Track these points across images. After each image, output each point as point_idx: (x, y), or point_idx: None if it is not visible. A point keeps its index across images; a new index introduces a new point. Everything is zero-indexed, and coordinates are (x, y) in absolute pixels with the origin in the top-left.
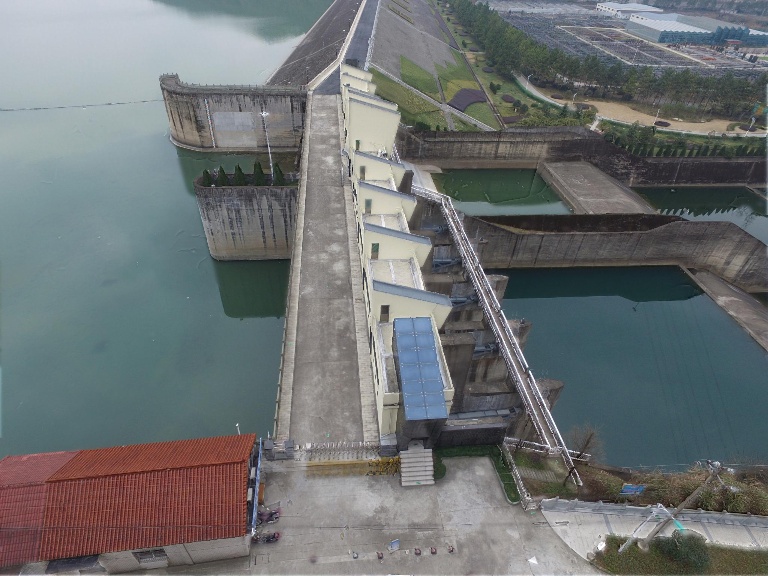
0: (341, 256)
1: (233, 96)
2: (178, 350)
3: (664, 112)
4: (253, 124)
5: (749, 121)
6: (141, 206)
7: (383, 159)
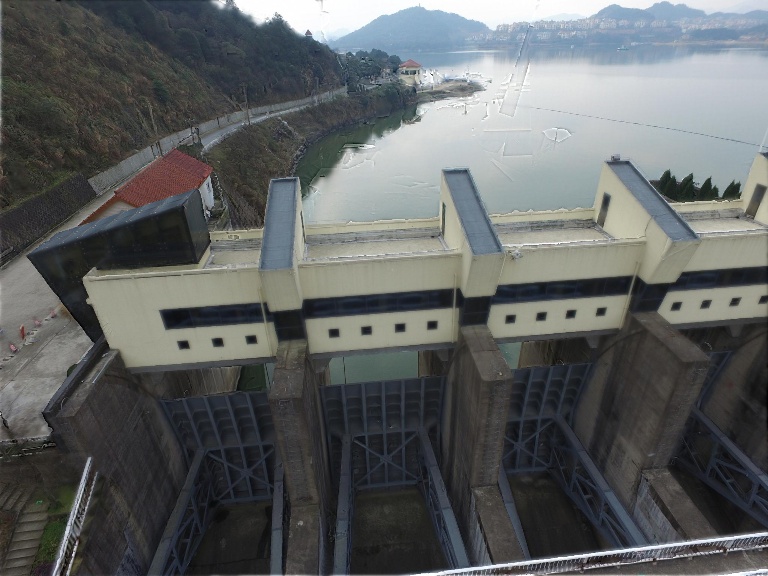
0: None
1: None
2: None
3: None
4: None
5: None
6: None
7: None
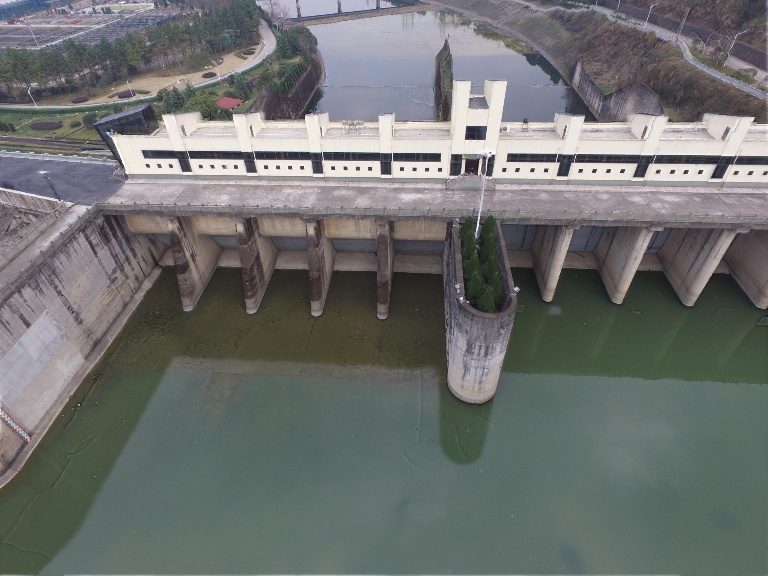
0: (652, 196)
1: (1, 310)
2: (688, 422)
3: (191, 66)
4: (58, 329)
5: (238, 48)
6: (265, 574)
7: (563, 114)
